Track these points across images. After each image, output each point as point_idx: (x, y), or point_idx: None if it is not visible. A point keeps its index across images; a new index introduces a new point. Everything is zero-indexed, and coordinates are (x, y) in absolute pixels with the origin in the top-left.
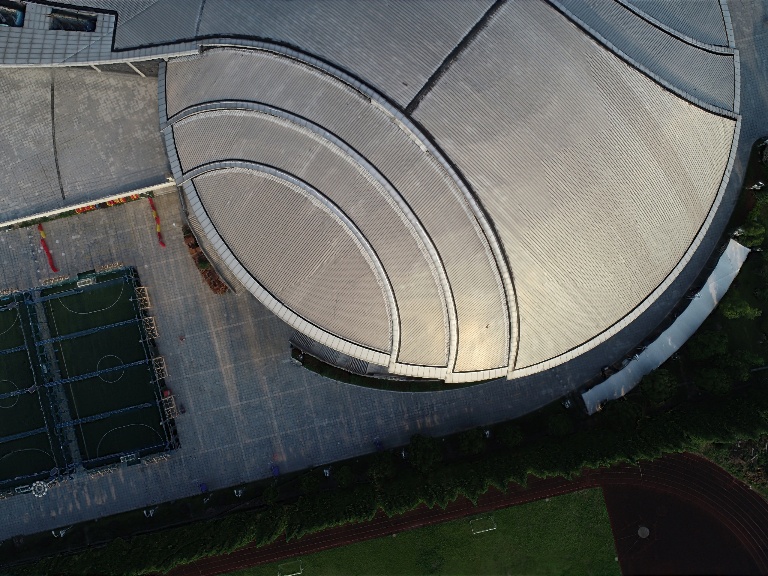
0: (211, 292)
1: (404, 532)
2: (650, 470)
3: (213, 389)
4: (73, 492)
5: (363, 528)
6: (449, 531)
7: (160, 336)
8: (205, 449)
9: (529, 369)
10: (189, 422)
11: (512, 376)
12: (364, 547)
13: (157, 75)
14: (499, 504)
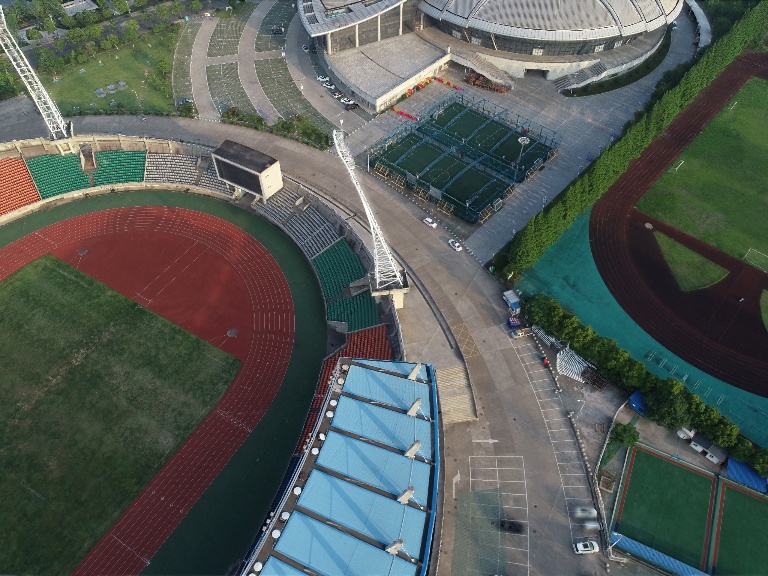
0: (501, 94)
1: (703, 129)
2: (760, 63)
3: (545, 124)
4: (524, 197)
5: (684, 137)
6: (721, 119)
7: (496, 118)
8: (570, 146)
9: (671, 16)
10: (549, 140)
11: (668, 21)
12: (695, 143)
13: (406, 33)
14: (725, 100)
